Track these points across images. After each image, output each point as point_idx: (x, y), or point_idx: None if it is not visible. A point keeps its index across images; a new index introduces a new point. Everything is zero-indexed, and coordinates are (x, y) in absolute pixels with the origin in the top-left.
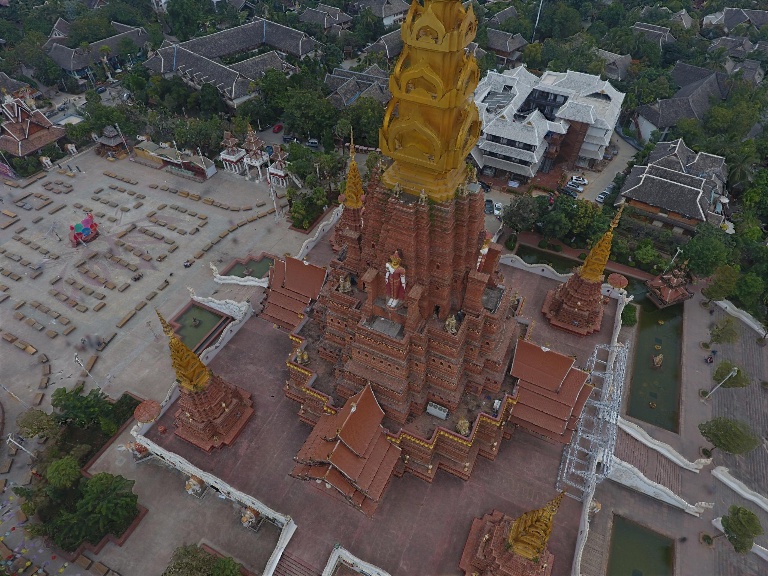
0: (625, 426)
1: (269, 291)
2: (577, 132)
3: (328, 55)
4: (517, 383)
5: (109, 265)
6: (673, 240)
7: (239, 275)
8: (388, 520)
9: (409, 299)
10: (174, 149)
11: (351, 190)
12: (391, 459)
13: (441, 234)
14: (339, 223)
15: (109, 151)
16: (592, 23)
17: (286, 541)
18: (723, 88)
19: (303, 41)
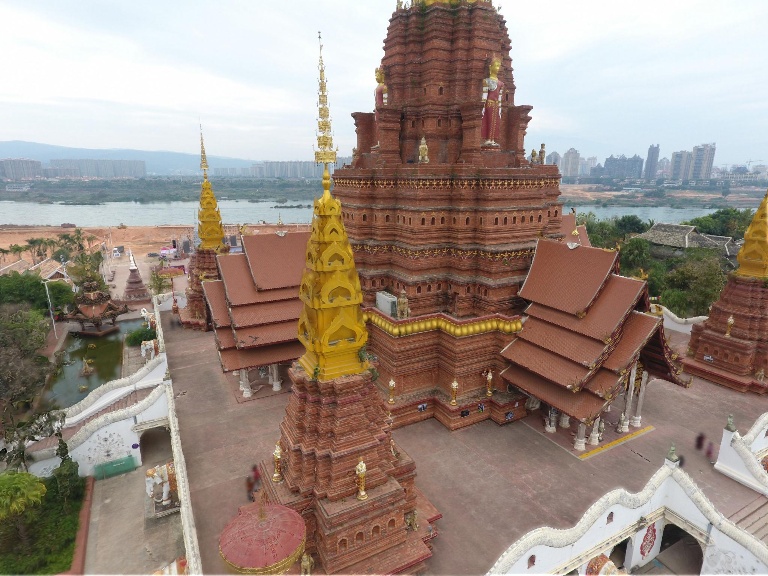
0: None
1: None
2: None
3: None
4: None
5: None
6: None
7: None
8: None
9: None
10: None
11: None
12: None
13: None
14: (387, 476)
15: None
16: None
17: None
18: None
19: None
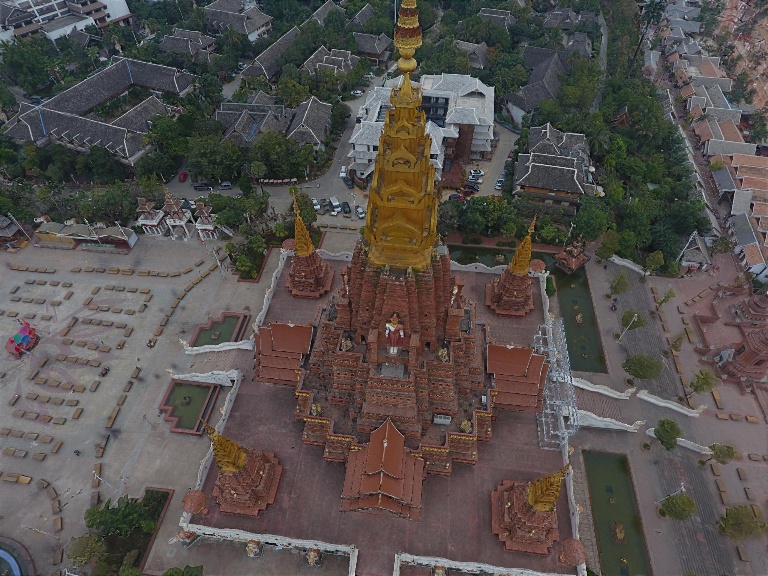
0: (573, 382)
1: (258, 356)
2: (466, 132)
3: (206, 86)
4: (494, 377)
5: (67, 368)
6: (563, 213)
7: (208, 341)
8: (427, 517)
9: (411, 347)
10: (83, 225)
11: (301, 241)
12: (419, 470)
13: (426, 292)
14: (292, 270)
15: (7, 242)
16: (444, 13)
17: (354, 565)
18: (566, 64)
19: (177, 77)
